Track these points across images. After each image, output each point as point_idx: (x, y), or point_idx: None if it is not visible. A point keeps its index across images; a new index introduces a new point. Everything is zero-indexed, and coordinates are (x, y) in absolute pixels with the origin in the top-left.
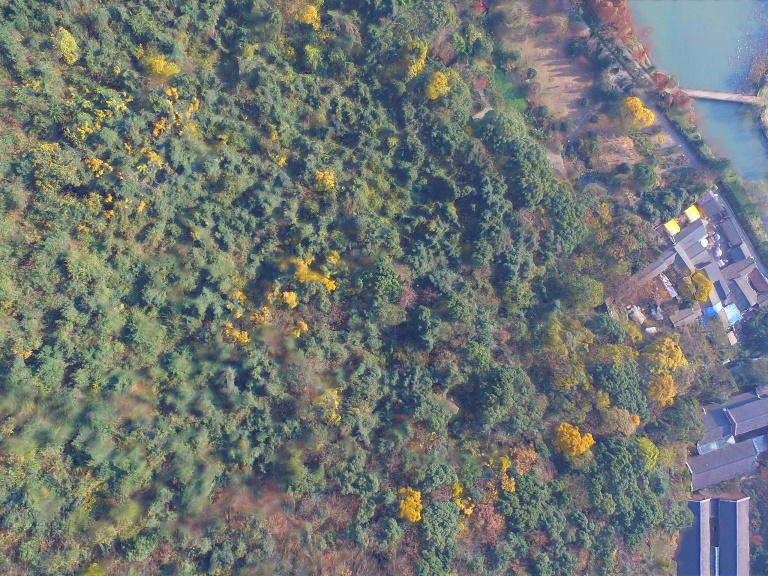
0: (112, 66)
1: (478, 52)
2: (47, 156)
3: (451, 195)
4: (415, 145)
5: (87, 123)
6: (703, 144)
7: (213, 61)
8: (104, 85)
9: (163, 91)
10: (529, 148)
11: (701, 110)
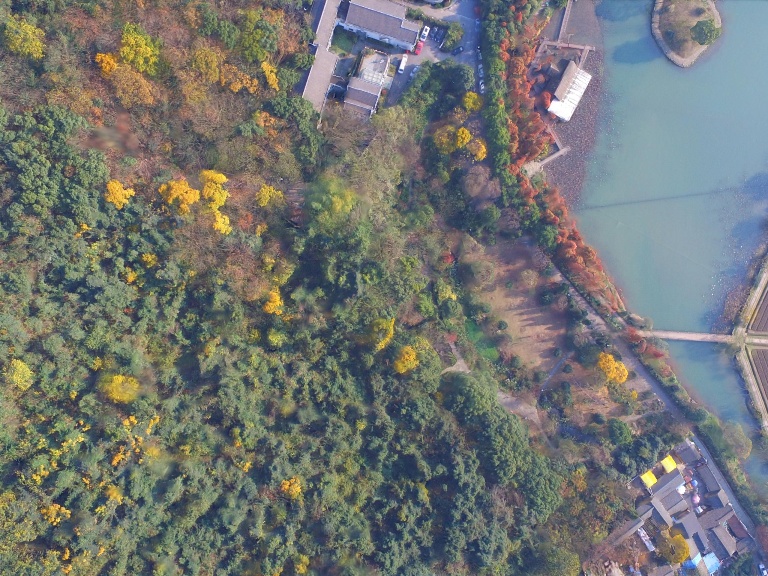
0: (68, 390)
1: (447, 317)
2: (1, 515)
3: (422, 476)
4: (384, 422)
5: (42, 466)
6: (678, 390)
7: (174, 357)
8: (61, 408)
9: (121, 422)
10: (501, 420)
11: (676, 350)
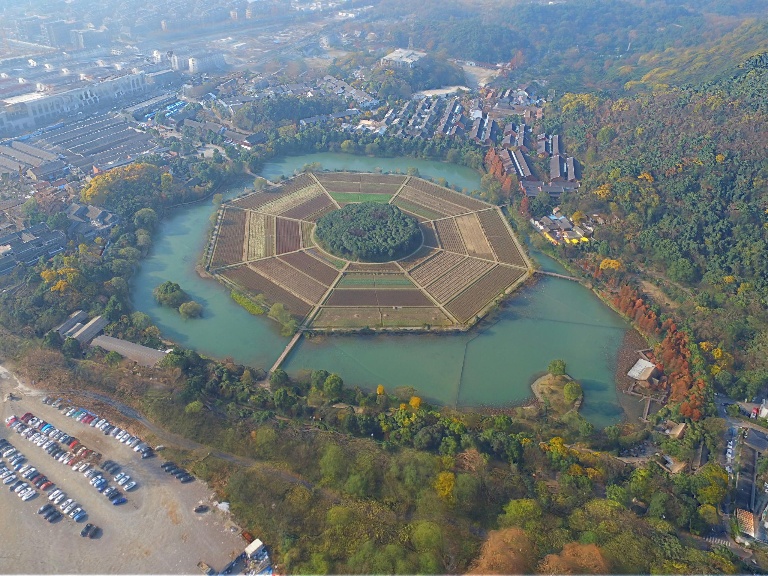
0: None
1: None
2: None
3: None
4: None
5: None
6: None
7: None
8: None
9: None
10: None
11: None
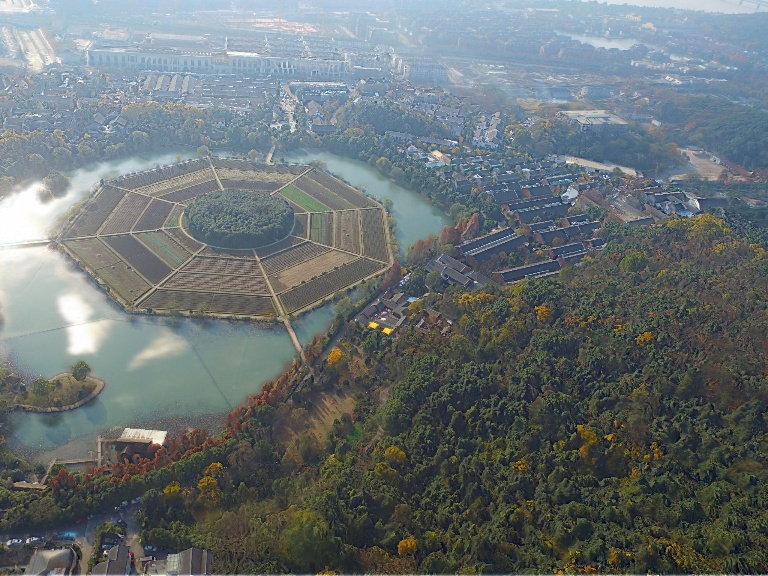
0: None
1: None
2: None
3: None
4: None
5: None
6: None
7: None
8: None
9: (564, 575)
10: None
11: None
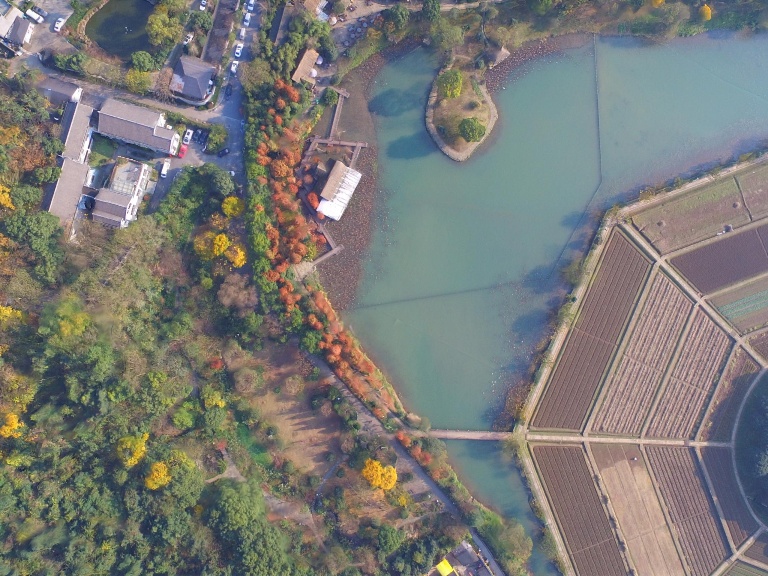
0: None
1: None
2: None
3: None
4: (136, 541)
5: None
6: (455, 491)
7: None
8: None
9: None
10: (256, 535)
11: (457, 448)
